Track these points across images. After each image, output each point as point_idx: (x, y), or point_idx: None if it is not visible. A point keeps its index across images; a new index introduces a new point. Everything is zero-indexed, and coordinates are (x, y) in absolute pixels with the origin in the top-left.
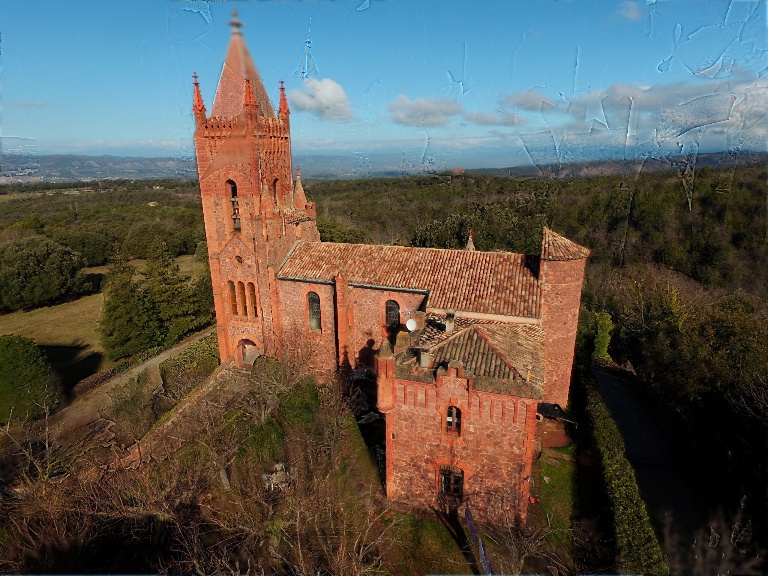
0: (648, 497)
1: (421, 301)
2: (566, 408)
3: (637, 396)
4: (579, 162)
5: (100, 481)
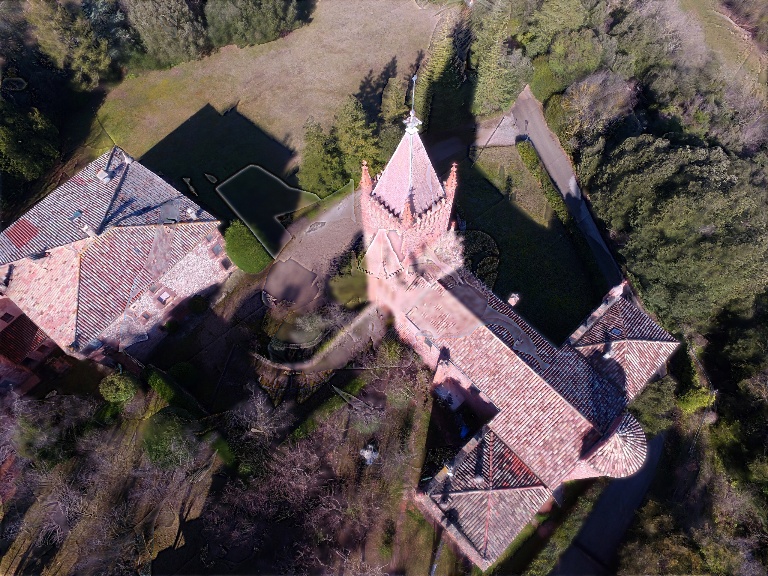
0: (558, 572)
1: None
2: (573, 480)
3: (658, 476)
4: None
5: (279, 486)
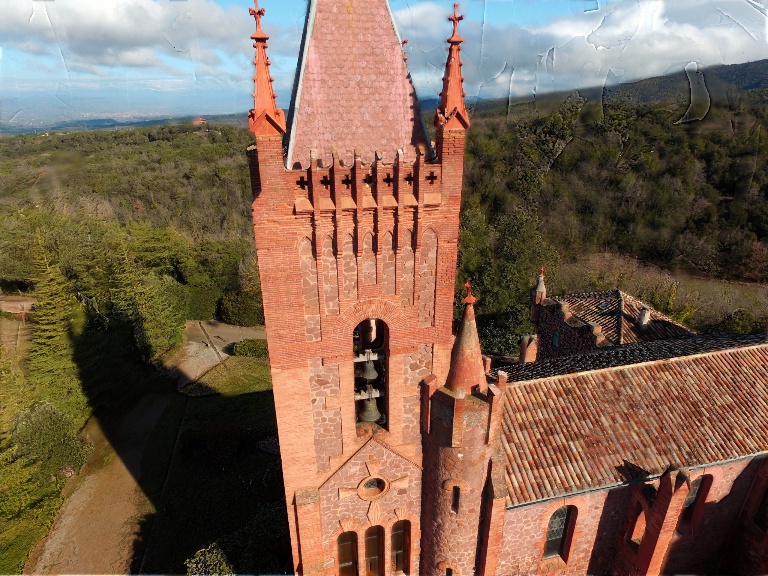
0: None
1: (748, 463)
2: None
3: None
4: (466, 135)
5: None
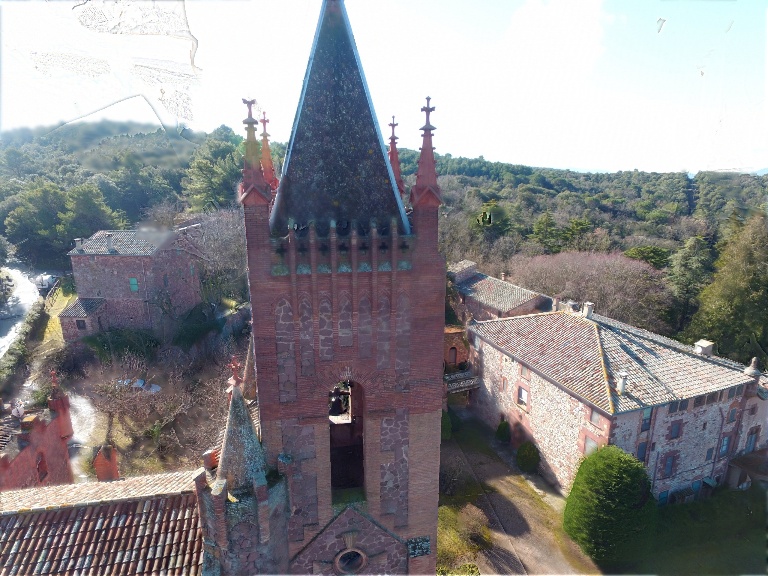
0: None
1: None
2: None
3: None
4: None
5: None
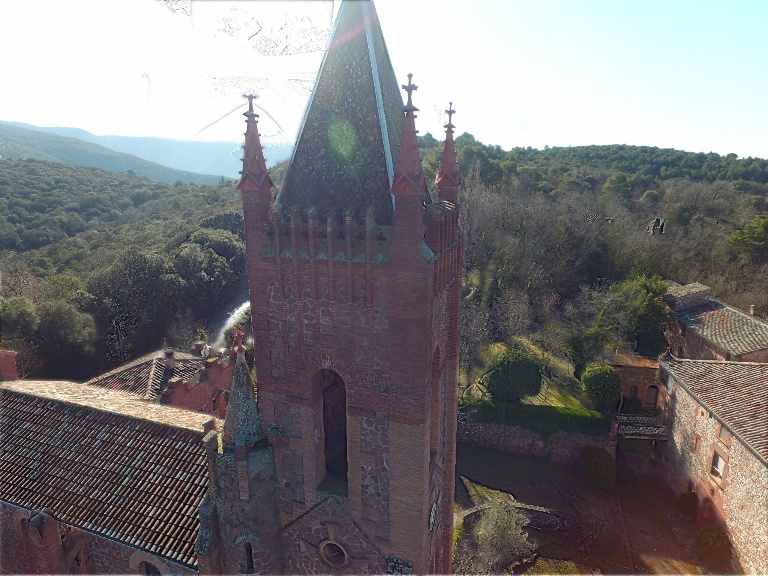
0: None
1: None
2: None
3: None
4: None
5: None
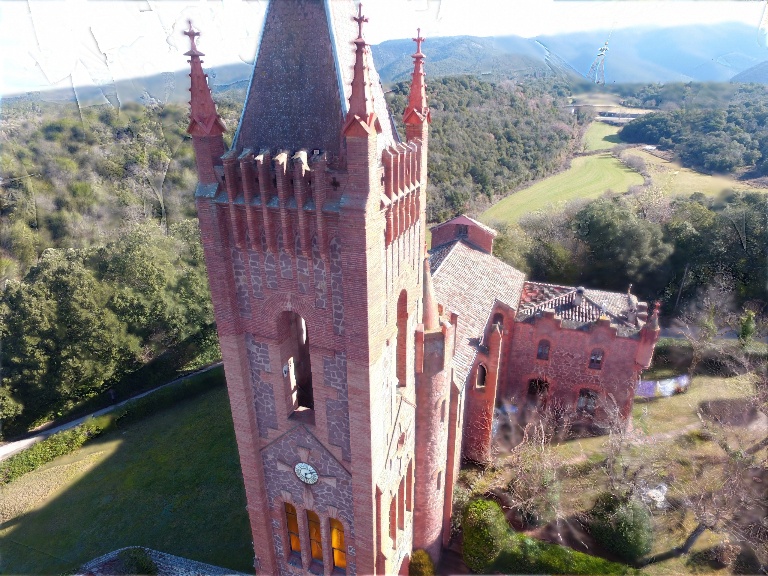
0: None
1: None
2: None
3: None
4: (38, 146)
5: None
